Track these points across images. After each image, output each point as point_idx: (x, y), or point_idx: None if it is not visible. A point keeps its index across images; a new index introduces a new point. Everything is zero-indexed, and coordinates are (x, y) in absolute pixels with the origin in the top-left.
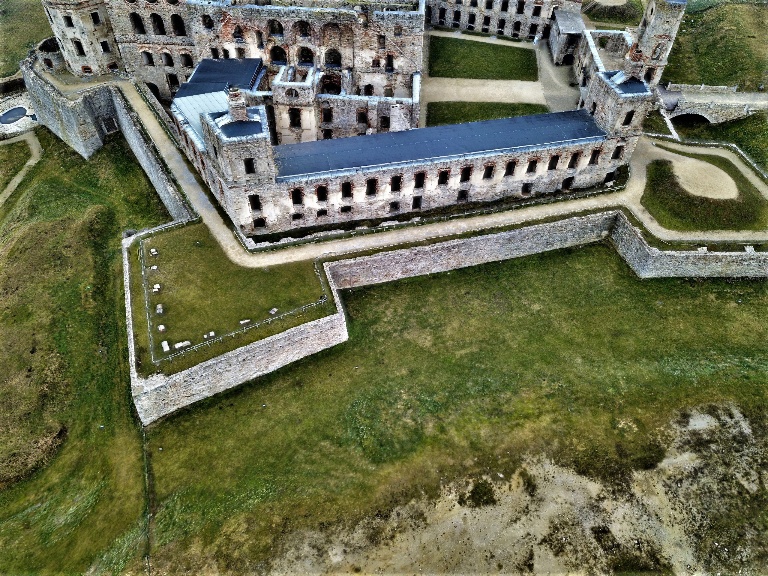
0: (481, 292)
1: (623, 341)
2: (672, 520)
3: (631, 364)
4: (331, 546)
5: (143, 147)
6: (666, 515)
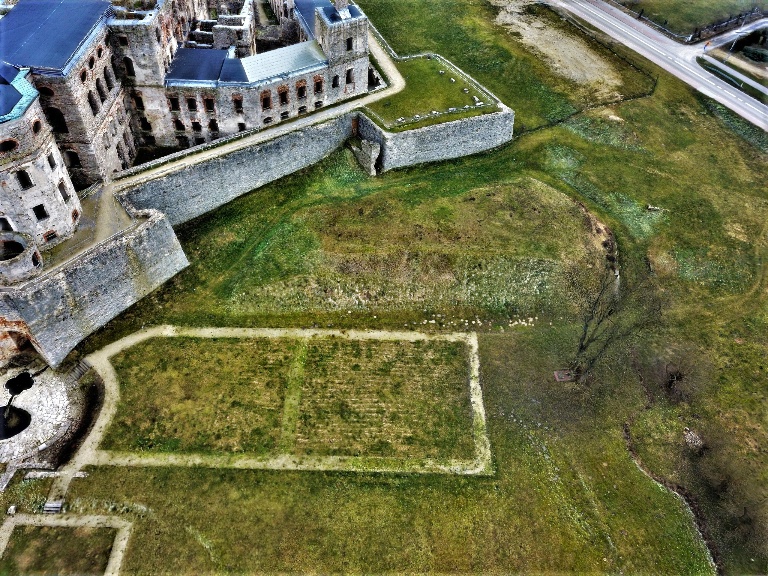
0: (389, 36)
1: (416, 5)
2: (509, 2)
3: (432, 3)
4: (554, 66)
5: (256, 150)
6: (507, 2)
